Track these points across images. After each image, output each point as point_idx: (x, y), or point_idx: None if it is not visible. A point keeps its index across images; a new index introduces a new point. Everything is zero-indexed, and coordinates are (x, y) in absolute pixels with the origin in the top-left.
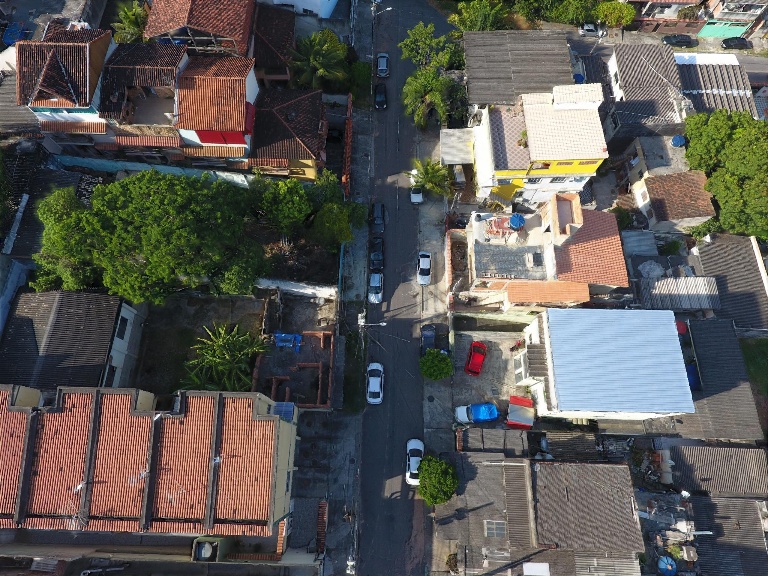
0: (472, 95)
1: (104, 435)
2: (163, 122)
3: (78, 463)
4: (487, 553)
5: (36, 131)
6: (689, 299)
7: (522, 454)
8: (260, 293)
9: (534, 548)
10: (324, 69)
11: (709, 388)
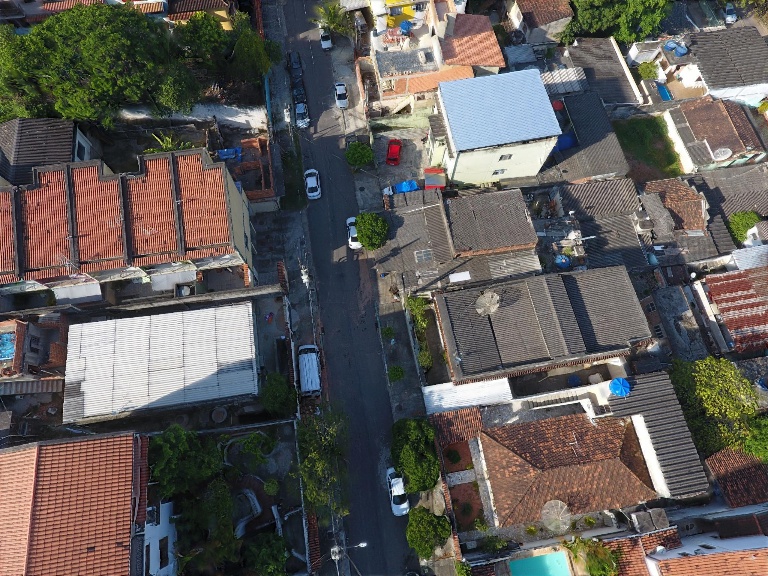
0: None
1: (80, 200)
2: None
3: (62, 224)
4: (420, 274)
5: None
6: (563, 86)
7: None
8: (200, 126)
9: (455, 261)
10: None
11: (584, 142)
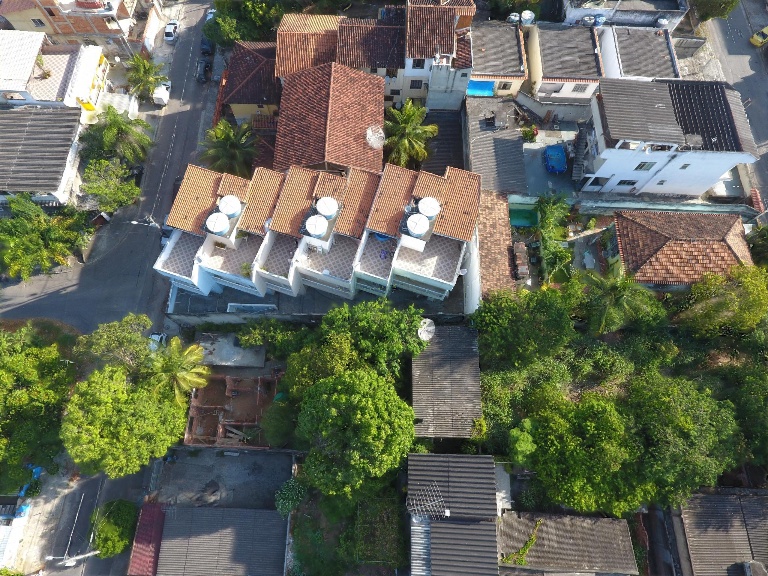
0: (75, 117)
1: None
2: None
3: None
4: None
5: None
6: None
7: None
8: None
9: None
10: None
11: None
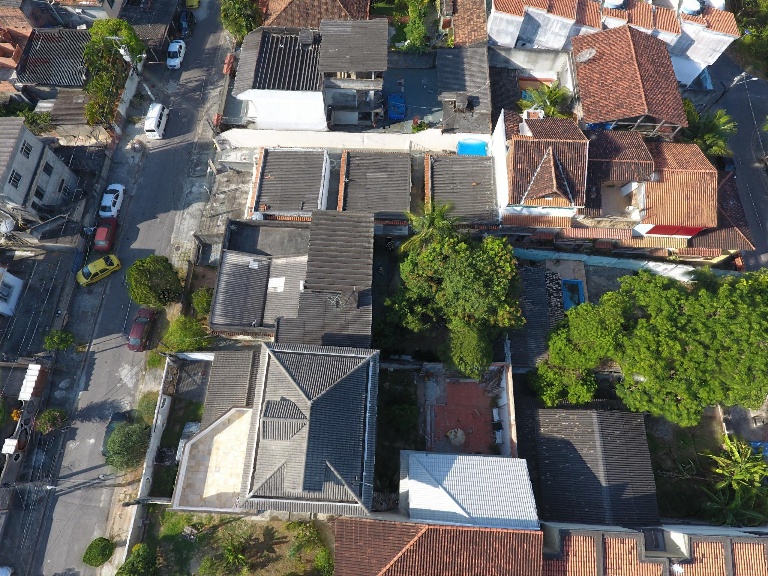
0: None
1: None
2: (614, 213)
3: None
4: None
5: (491, 224)
6: None
7: None
8: None
9: None
10: (718, 147)
11: None
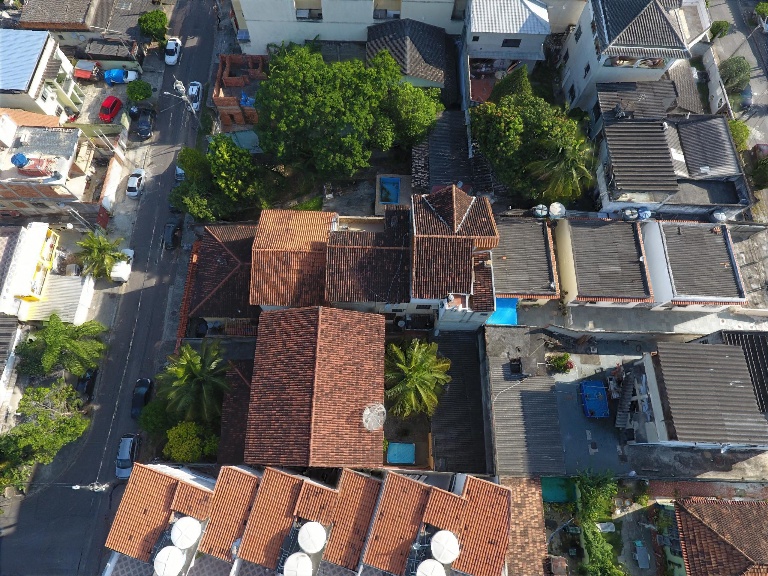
0: (10, 330)
1: None
2: None
3: None
4: None
5: None
6: None
7: (93, 41)
8: None
9: None
10: None
11: None
